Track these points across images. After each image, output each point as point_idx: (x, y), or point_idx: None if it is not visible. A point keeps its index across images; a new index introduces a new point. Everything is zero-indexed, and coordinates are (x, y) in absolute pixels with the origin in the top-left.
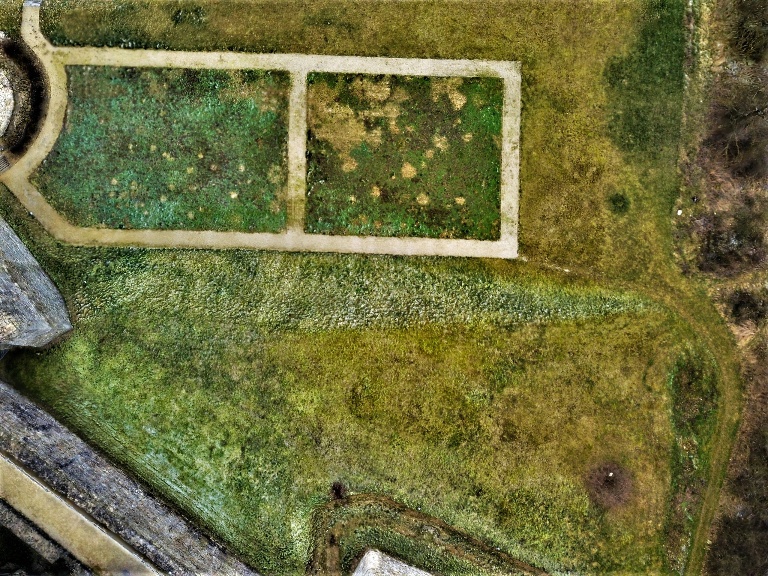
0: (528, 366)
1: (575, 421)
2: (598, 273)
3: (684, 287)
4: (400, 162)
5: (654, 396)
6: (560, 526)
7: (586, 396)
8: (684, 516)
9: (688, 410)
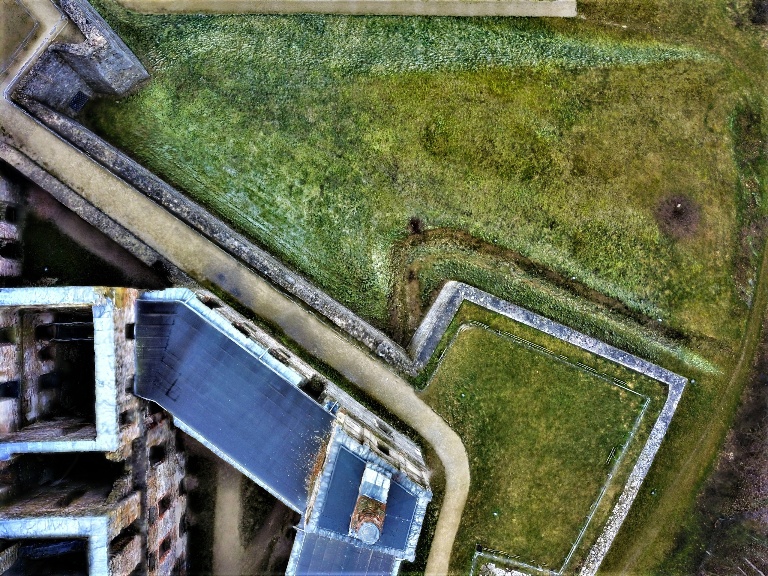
0: (594, 106)
1: (642, 157)
2: (655, 28)
3: (738, 39)
4: None
5: (716, 136)
6: (632, 254)
7: (651, 134)
8: (749, 249)
9: (748, 151)
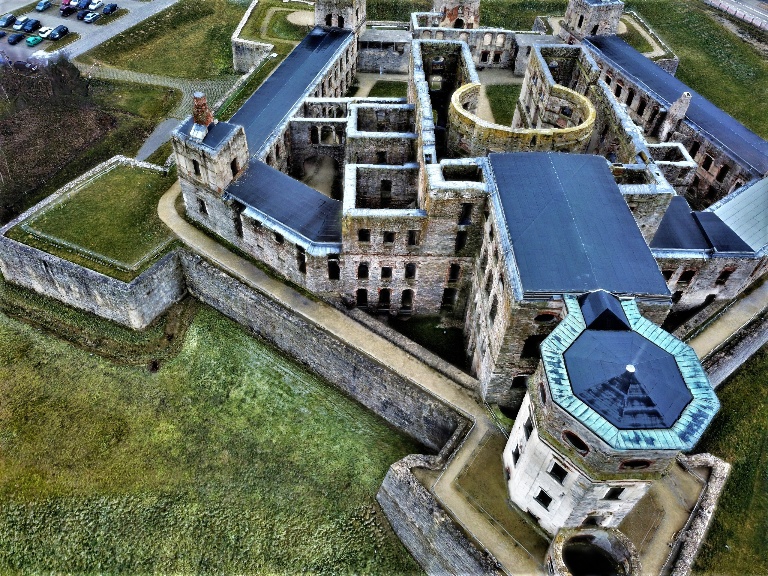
0: None
1: None
2: None
3: None
4: None
5: None
6: None
7: None
8: None
9: None
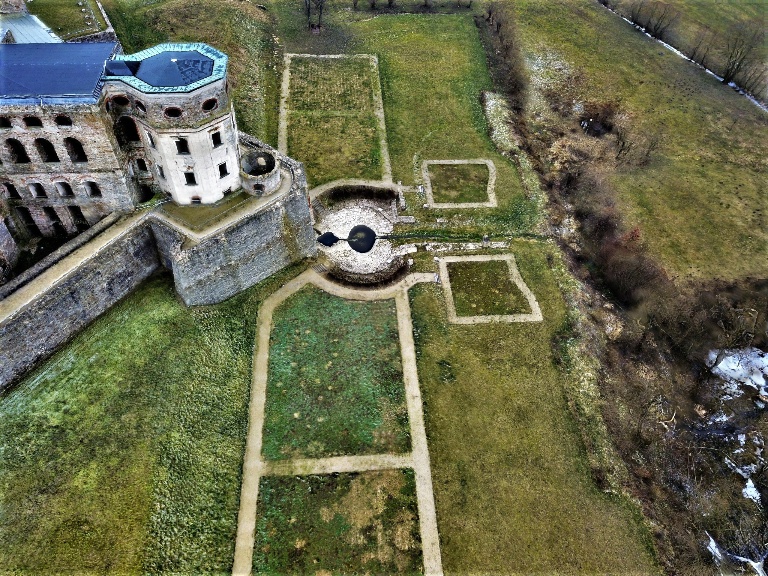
0: None
1: None
2: None
3: None
4: (332, 567)
5: None
6: None
7: None
8: None
9: None
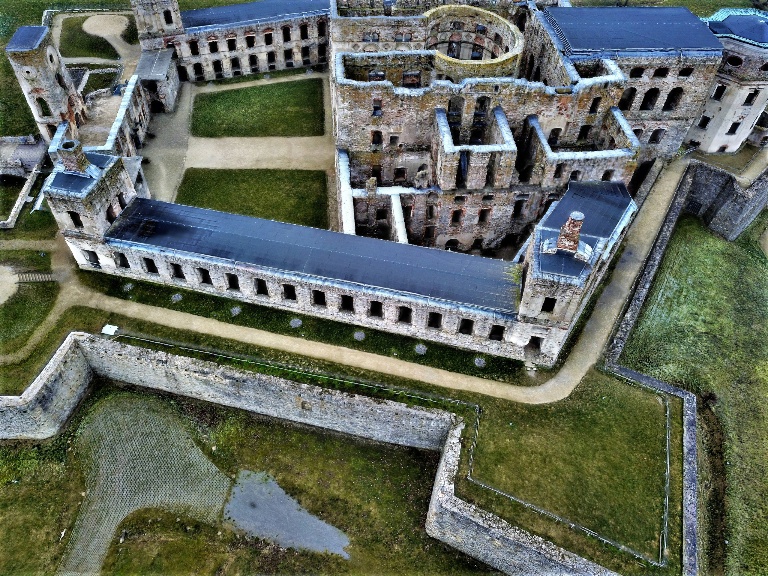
0: None
1: None
2: None
3: None
4: None
5: None
6: None
7: None
8: None
9: None
